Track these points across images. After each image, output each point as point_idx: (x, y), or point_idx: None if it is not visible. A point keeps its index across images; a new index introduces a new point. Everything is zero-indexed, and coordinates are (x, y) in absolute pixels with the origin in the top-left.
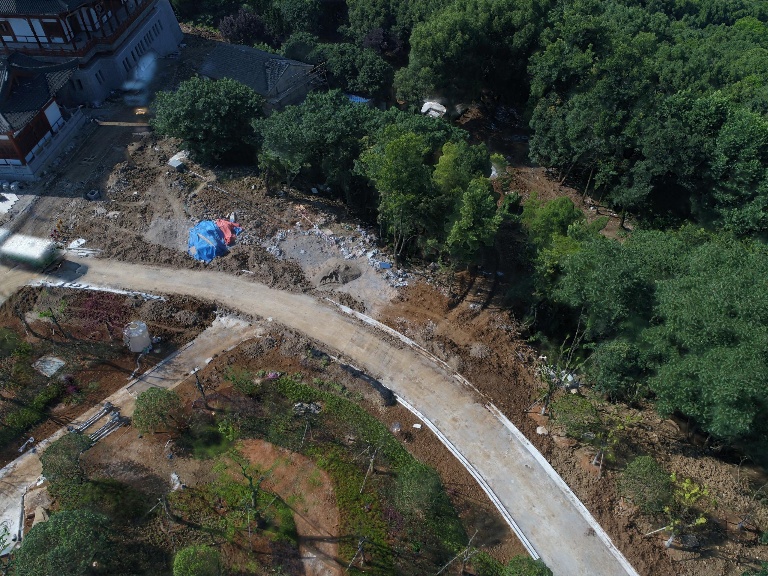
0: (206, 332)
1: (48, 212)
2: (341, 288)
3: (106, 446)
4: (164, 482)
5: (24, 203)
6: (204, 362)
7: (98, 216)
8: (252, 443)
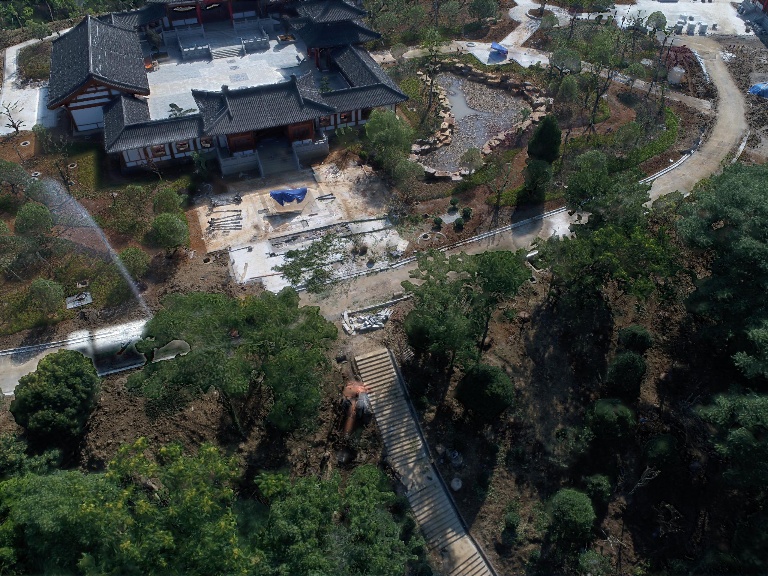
0: (695, 98)
1: (749, 45)
2: (765, 139)
3: (613, 81)
4: (603, 94)
5: (750, 37)
6: (674, 99)
7: (759, 58)
8: (633, 112)
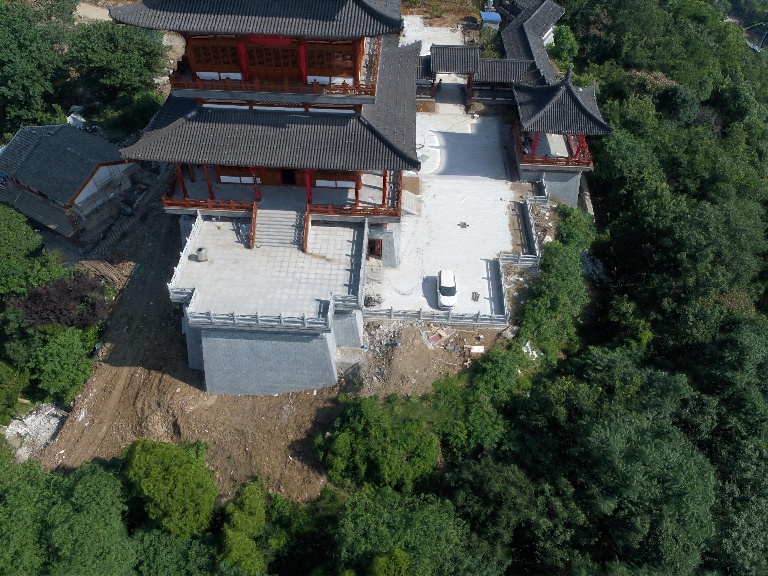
0: None
1: None
2: None
3: None
4: None
5: None
6: None
7: None
8: None
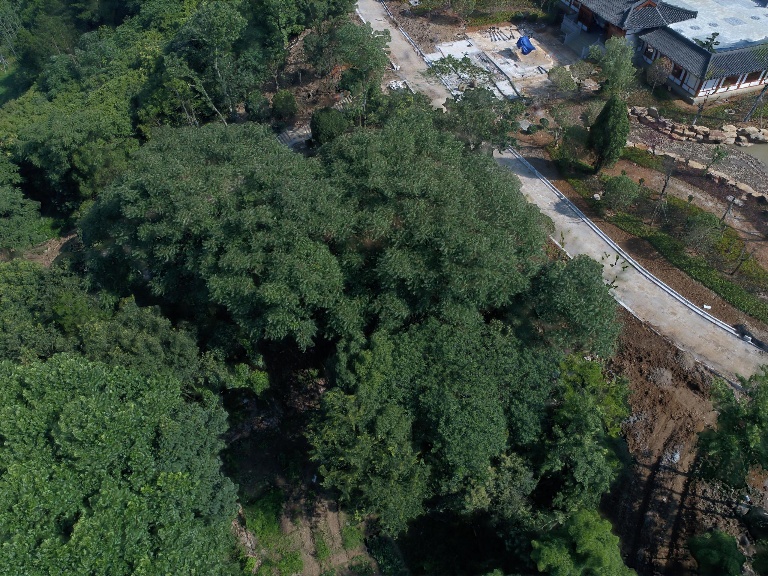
0: None
1: None
2: None
3: None
4: None
5: None
6: None
7: None
8: None
